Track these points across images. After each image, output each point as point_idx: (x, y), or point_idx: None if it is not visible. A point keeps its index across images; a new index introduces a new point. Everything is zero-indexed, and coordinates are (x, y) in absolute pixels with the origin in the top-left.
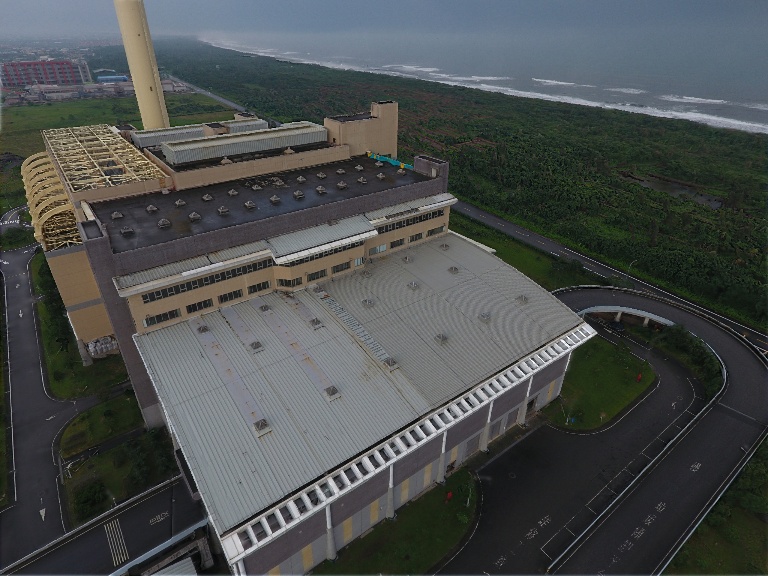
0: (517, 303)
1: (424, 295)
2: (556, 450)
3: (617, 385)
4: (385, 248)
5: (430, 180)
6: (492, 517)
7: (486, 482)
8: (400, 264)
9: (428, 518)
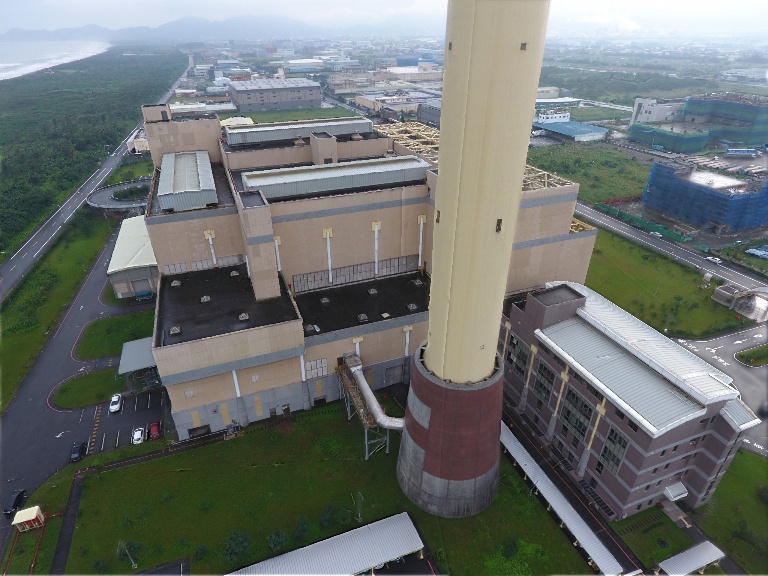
0: None
1: None
2: None
3: None
4: None
5: None
6: None
7: None
8: None
9: None
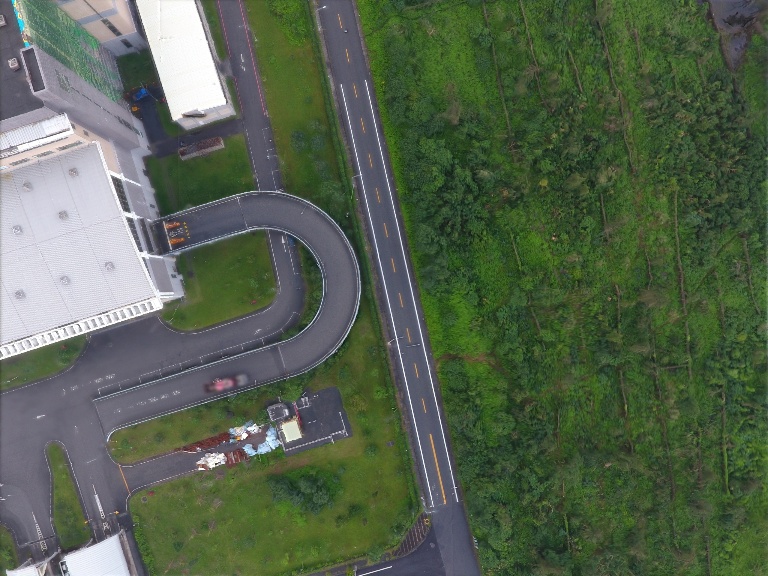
0: (104, 268)
1: (24, 243)
2: (148, 338)
3: (233, 302)
4: (7, 166)
5: (26, 113)
6: (83, 365)
7: (92, 344)
8: (19, 191)
9: (47, 355)
